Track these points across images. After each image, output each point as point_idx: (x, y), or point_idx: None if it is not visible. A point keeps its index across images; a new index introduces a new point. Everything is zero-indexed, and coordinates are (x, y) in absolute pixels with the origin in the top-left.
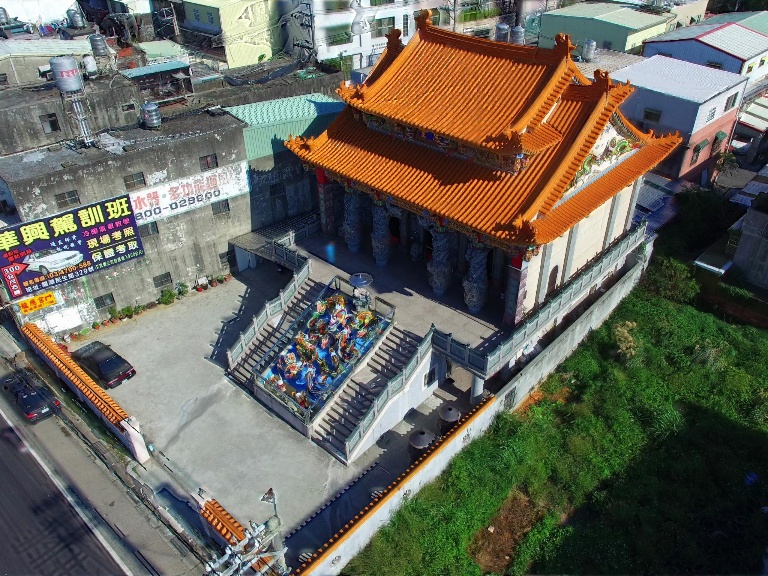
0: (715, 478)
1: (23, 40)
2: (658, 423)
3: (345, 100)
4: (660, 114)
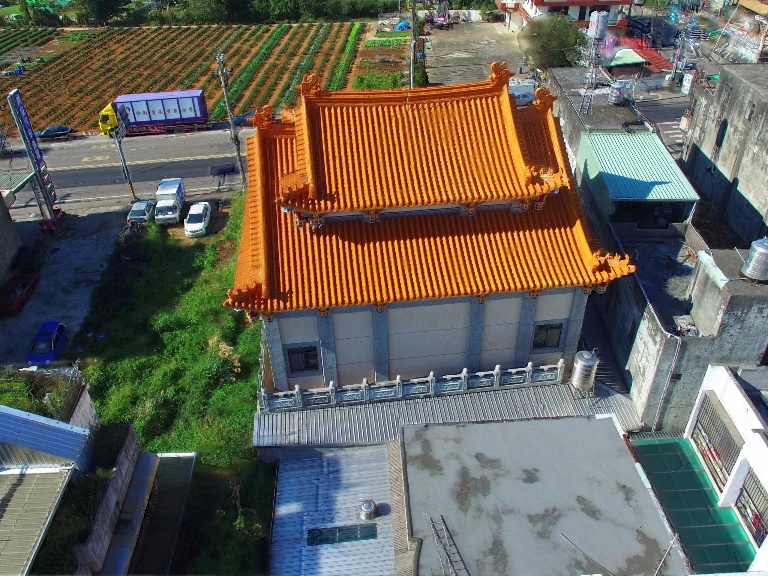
0: None
1: None
2: None
3: None
4: None
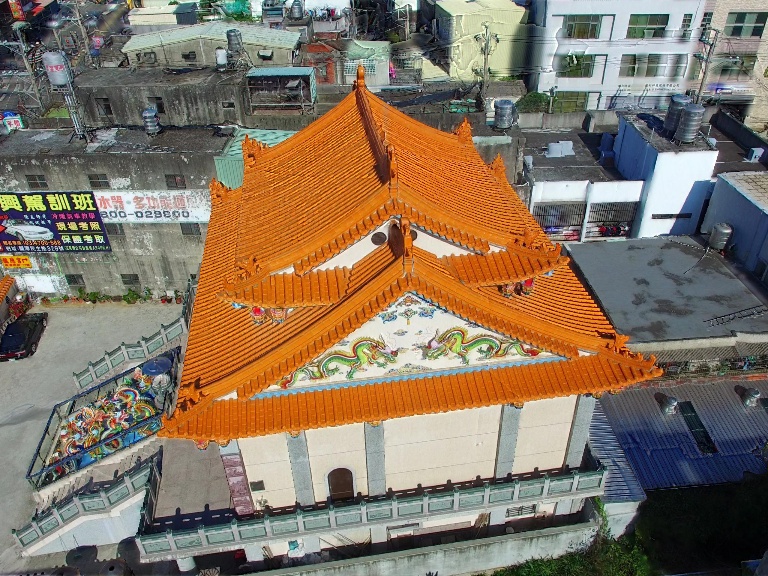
0: None
1: (235, 23)
2: None
3: None
4: None
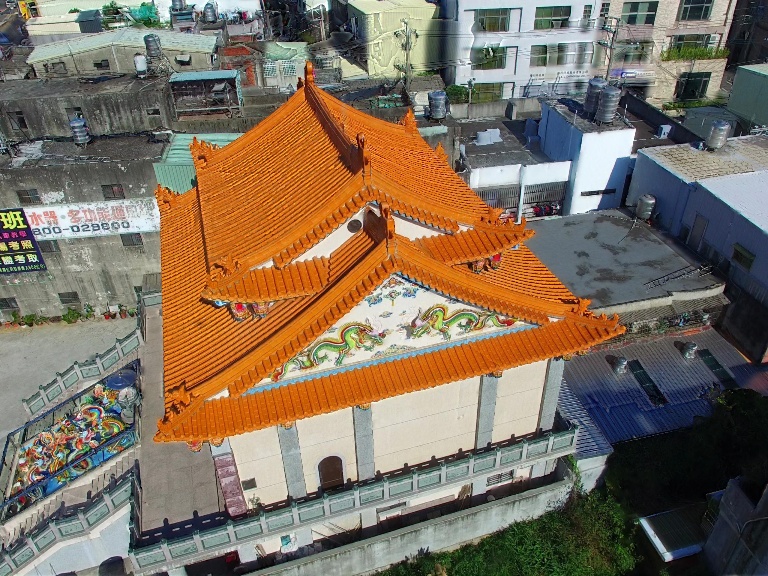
0: None
1: (147, 29)
2: None
3: None
4: (752, 259)
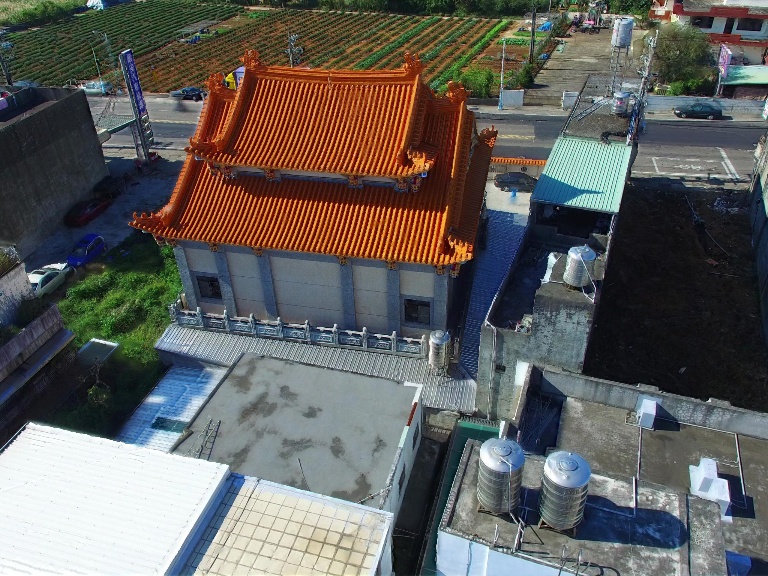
0: None
1: None
2: None
3: None
4: None
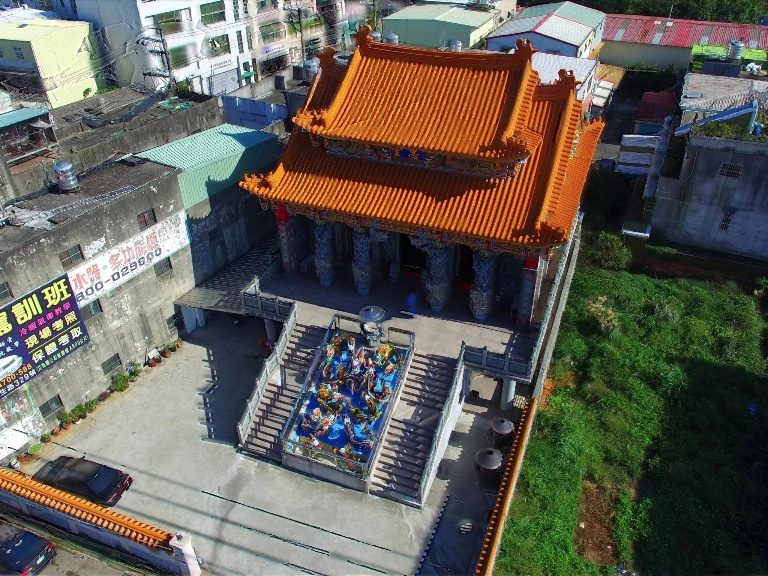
0: (729, 417)
1: None
2: (667, 382)
3: (305, 128)
4: None
